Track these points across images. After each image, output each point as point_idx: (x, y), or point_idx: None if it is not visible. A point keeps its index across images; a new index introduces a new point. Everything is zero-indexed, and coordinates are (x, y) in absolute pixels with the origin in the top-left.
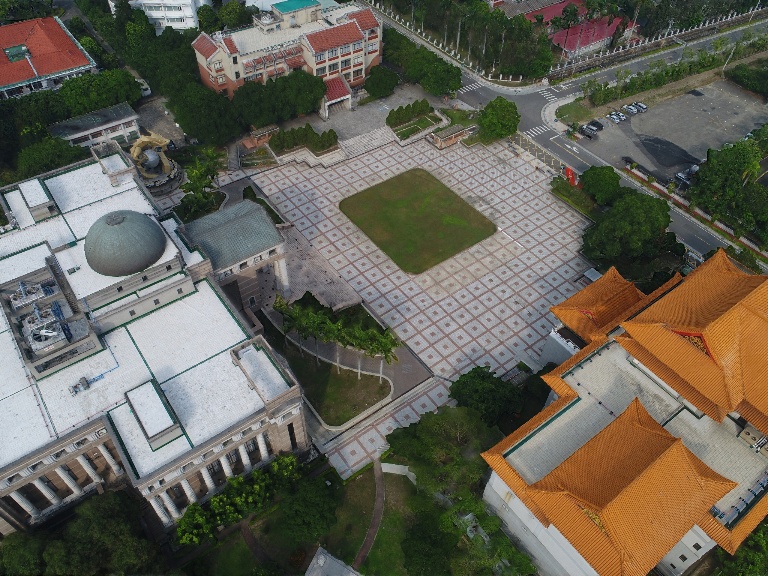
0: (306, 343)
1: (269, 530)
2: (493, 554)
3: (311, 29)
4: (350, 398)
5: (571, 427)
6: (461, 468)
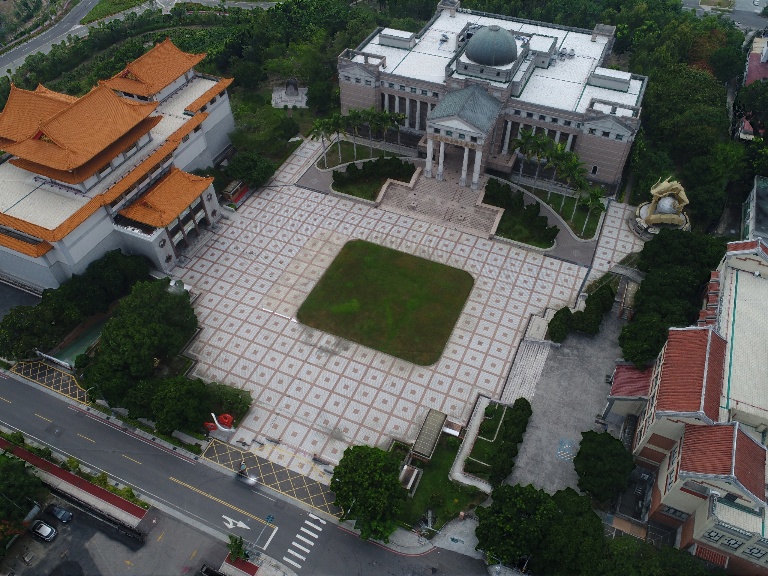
0: None
1: None
2: None
3: (752, 384)
4: None
5: (187, 102)
6: (249, 119)
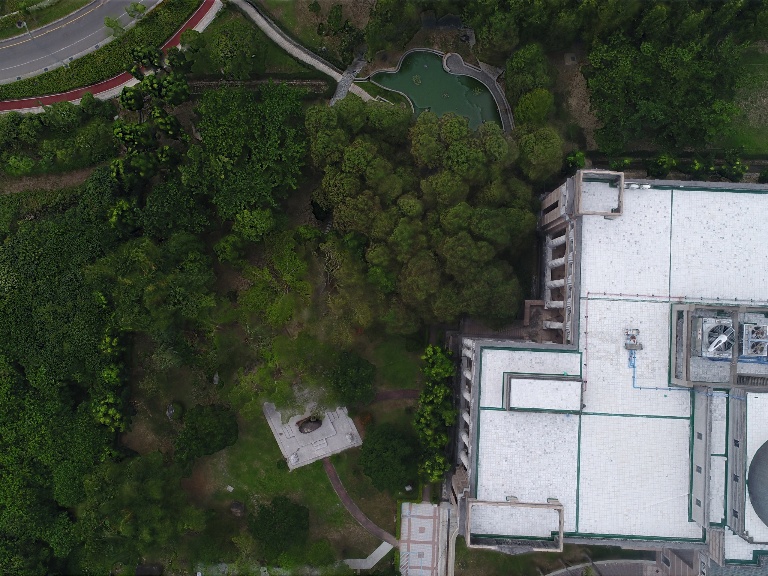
0: (575, 575)
1: (407, 414)
2: (238, 575)
3: None
4: (478, 570)
5: None
6: None
